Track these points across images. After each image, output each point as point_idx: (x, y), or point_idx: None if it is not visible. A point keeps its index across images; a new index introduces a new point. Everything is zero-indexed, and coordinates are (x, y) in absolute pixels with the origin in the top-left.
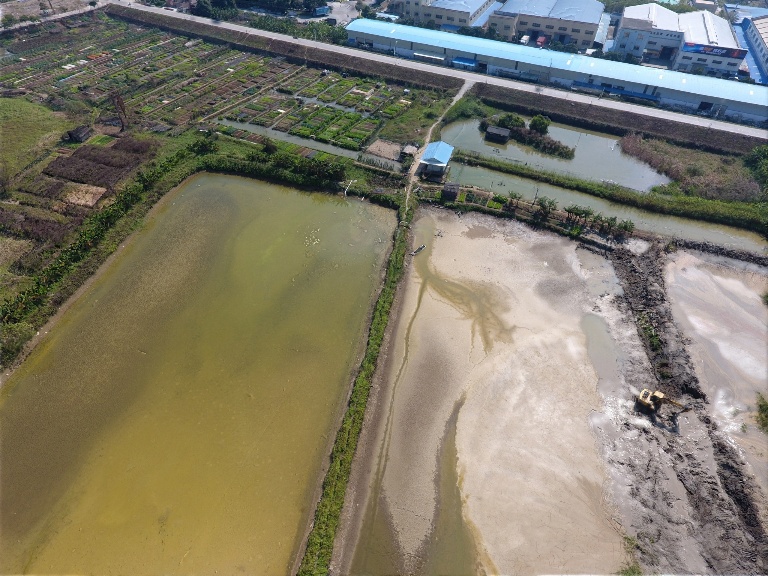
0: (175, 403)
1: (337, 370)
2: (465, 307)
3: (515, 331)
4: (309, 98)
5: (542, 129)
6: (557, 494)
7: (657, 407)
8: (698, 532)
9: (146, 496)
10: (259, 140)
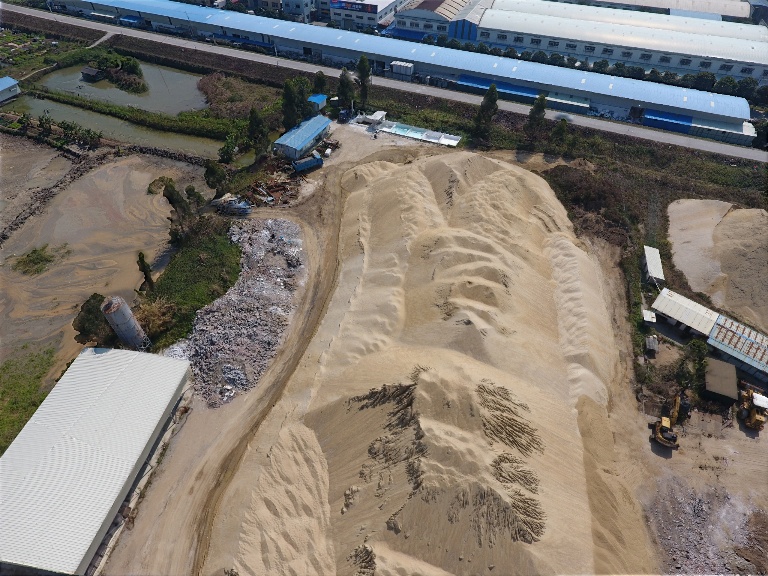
0: None
1: None
2: None
3: None
4: None
5: (128, 69)
6: None
7: None
8: None
9: None
10: None
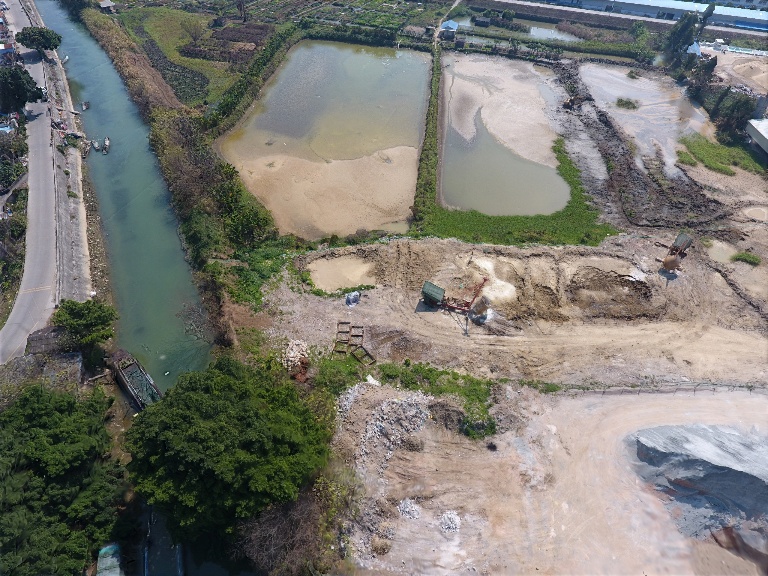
0: (345, 109)
1: (419, 100)
2: (477, 83)
3: (504, 89)
4: (356, 8)
5: (510, 18)
6: (528, 126)
7: (572, 105)
8: (587, 131)
9: (348, 129)
10: (335, 25)
